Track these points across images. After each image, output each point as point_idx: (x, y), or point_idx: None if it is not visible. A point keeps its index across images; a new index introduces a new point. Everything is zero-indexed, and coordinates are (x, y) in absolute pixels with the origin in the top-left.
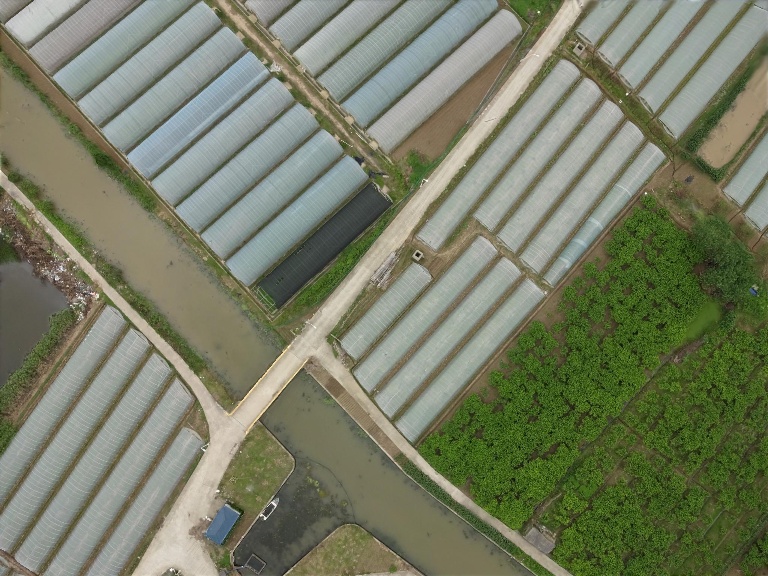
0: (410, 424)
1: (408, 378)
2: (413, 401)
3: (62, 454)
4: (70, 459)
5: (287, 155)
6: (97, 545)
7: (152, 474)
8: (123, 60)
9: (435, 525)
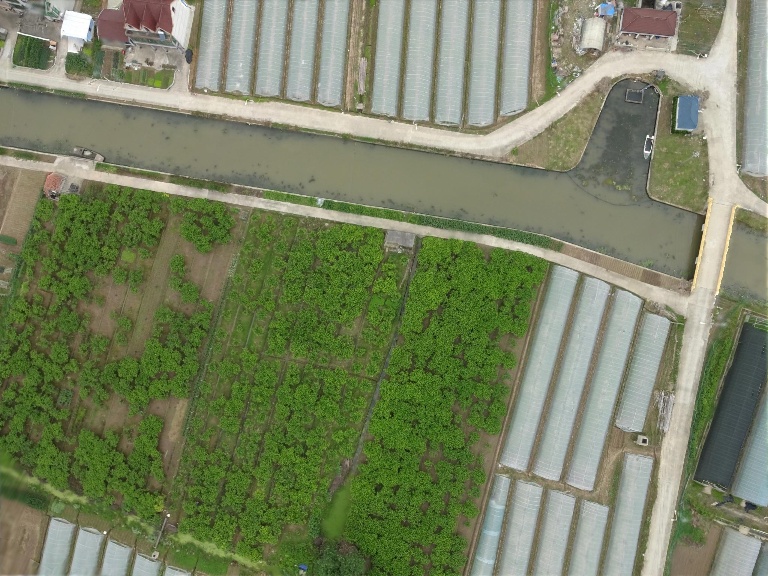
0: (568, 280)
1: (588, 320)
2: (573, 302)
3: None
4: None
5: None
6: None
7: None
8: None
9: (495, 206)
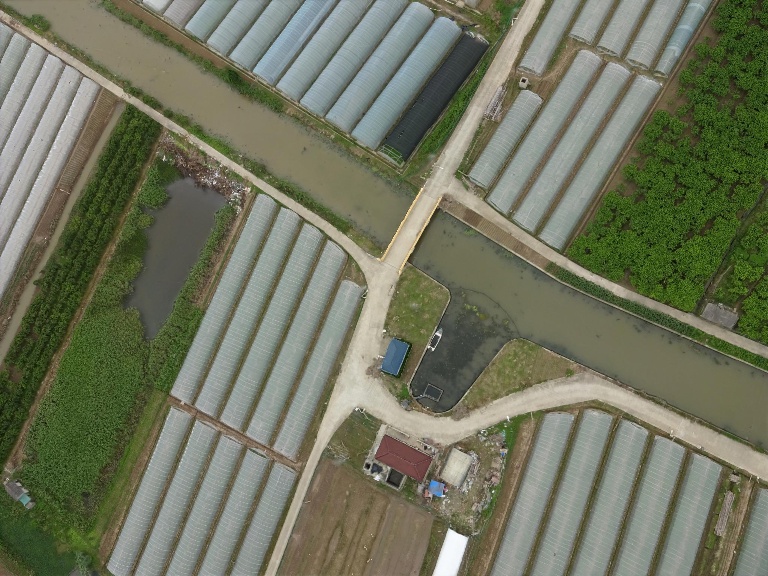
0: (553, 231)
1: (541, 194)
2: (551, 213)
3: (244, 323)
4: (251, 328)
5: (385, 34)
6: (287, 398)
7: (323, 327)
8: (236, 1)
9: (603, 326)
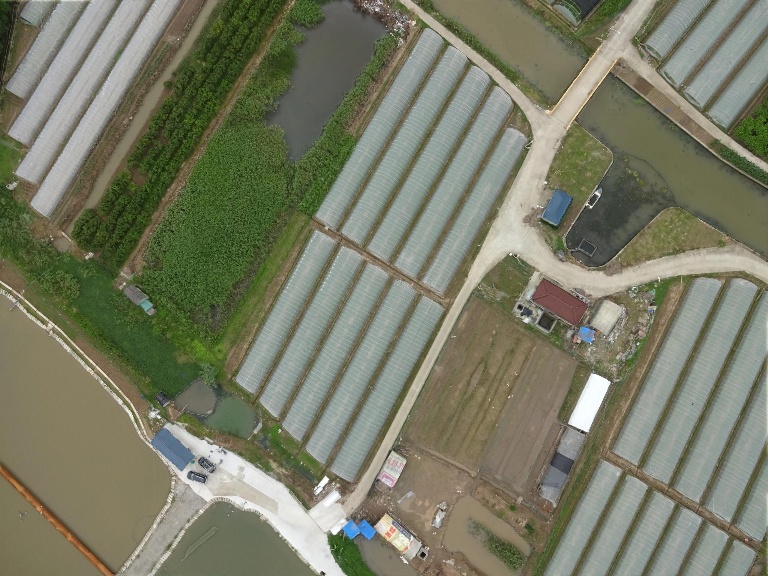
0: (723, 109)
1: None
2: (720, 93)
3: (402, 156)
4: (407, 162)
5: None
6: (440, 236)
7: (484, 170)
8: None
9: (755, 206)
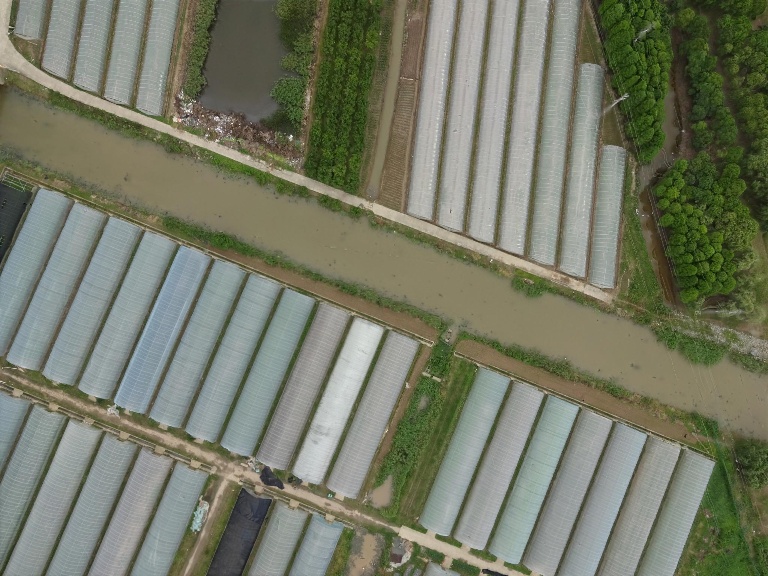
0: None
1: None
2: None
3: None
4: None
5: None
6: None
7: None
8: None
9: None
